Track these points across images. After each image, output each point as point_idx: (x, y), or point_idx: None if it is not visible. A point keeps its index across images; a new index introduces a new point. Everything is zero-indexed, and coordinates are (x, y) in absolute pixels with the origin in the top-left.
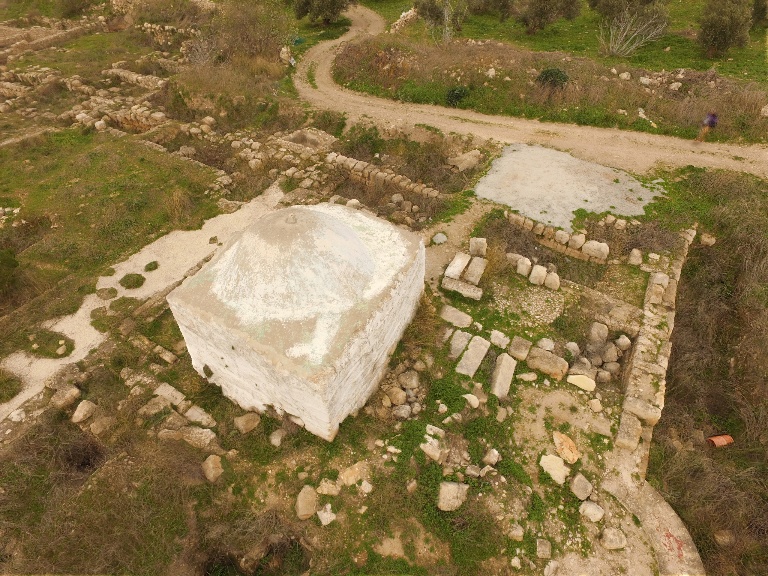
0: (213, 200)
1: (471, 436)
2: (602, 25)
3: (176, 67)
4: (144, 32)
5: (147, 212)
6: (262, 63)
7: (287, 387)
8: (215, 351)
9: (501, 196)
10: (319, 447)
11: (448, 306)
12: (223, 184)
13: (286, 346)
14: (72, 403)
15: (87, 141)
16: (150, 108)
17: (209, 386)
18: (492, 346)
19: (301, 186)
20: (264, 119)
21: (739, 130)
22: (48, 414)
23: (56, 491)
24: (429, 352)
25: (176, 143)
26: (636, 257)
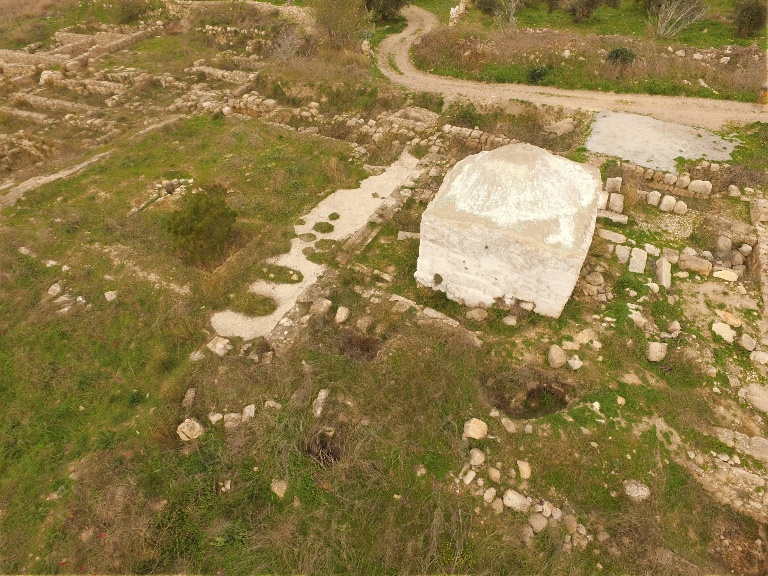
0: (358, 166)
1: (656, 313)
2: (651, 11)
3: (251, 63)
4: (205, 34)
5: (307, 177)
6: (350, 54)
7: (542, 269)
8: (458, 257)
9: (610, 150)
10: (549, 323)
11: (602, 229)
12: (361, 153)
13: (544, 237)
14: (327, 311)
15: (220, 125)
16: (258, 97)
17: (436, 292)
18: (648, 254)
19: (431, 151)
20: (365, 102)
21: None
22: (319, 316)
23: (358, 362)
24: (603, 260)
25: (291, 125)
26: (735, 190)
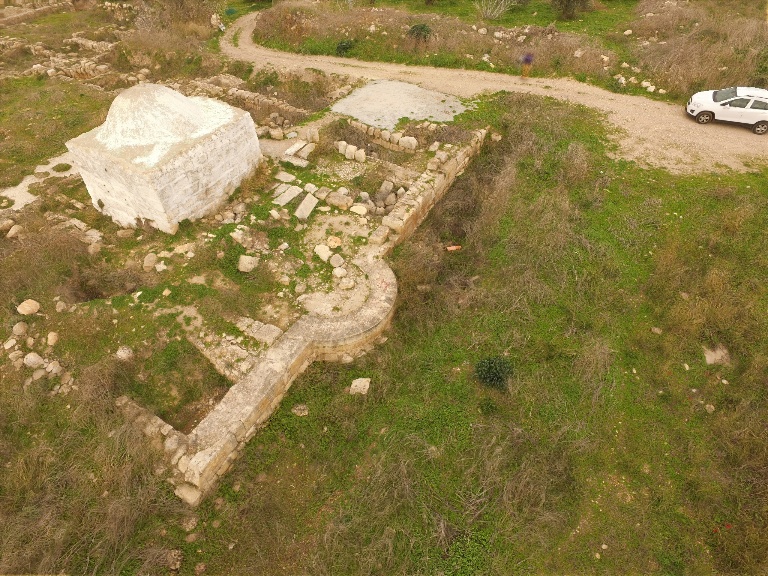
0: None
1: (272, 236)
2: None
3: None
4: (105, 10)
5: (80, 128)
6: (193, 27)
7: (135, 186)
8: (100, 181)
9: (349, 110)
10: (166, 238)
11: (282, 172)
12: None
13: (132, 158)
14: (8, 229)
15: (40, 84)
16: (97, 63)
17: (103, 216)
18: (304, 192)
19: None
20: (190, 70)
21: (554, 67)
22: None
23: None
24: (258, 194)
25: (116, 88)
26: (434, 146)
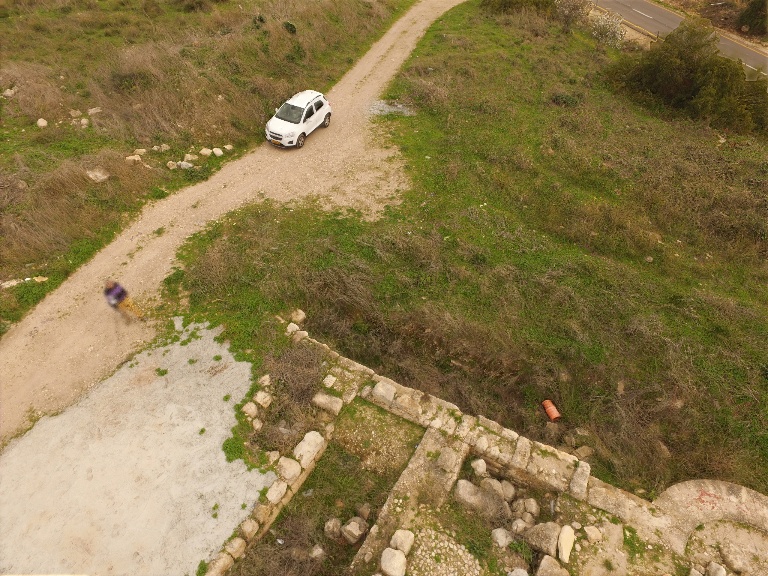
0: None
1: None
2: None
3: None
4: None
5: None
6: None
7: None
8: None
9: None
10: None
11: None
12: None
13: None
14: None
15: None
16: None
17: None
18: None
19: None
20: None
21: (112, 209)
22: None
23: None
24: None
25: None
26: (332, 403)
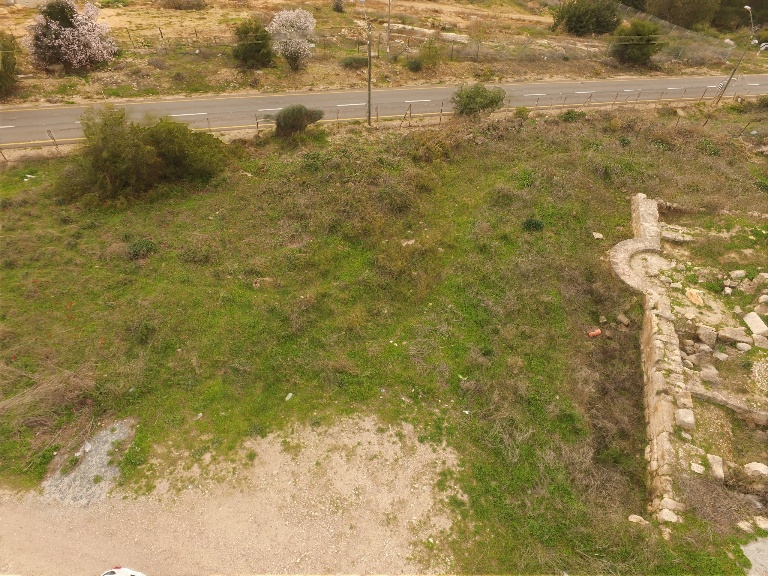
0: None
1: None
2: None
3: None
4: None
5: None
6: None
7: None
8: None
9: None
10: None
11: None
12: None
13: None
14: None
15: None
16: None
17: None
18: None
19: None
20: None
21: None
22: None
23: None
24: None
25: None
26: (717, 461)
